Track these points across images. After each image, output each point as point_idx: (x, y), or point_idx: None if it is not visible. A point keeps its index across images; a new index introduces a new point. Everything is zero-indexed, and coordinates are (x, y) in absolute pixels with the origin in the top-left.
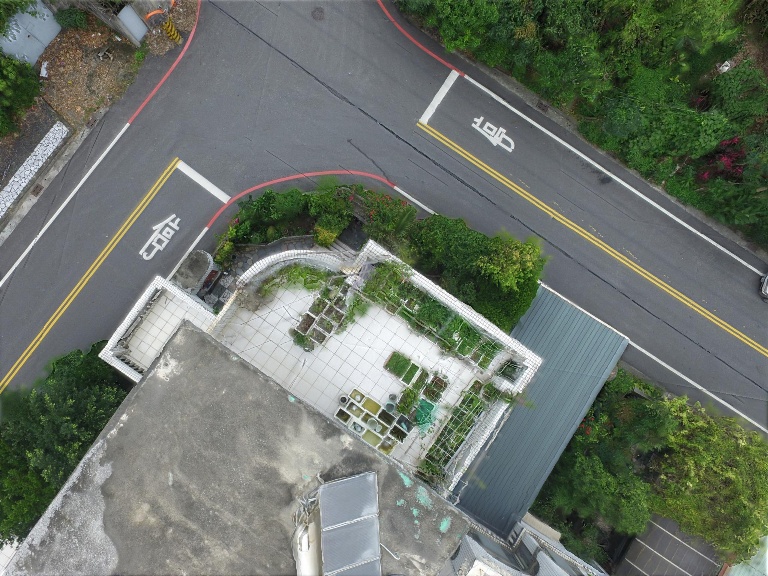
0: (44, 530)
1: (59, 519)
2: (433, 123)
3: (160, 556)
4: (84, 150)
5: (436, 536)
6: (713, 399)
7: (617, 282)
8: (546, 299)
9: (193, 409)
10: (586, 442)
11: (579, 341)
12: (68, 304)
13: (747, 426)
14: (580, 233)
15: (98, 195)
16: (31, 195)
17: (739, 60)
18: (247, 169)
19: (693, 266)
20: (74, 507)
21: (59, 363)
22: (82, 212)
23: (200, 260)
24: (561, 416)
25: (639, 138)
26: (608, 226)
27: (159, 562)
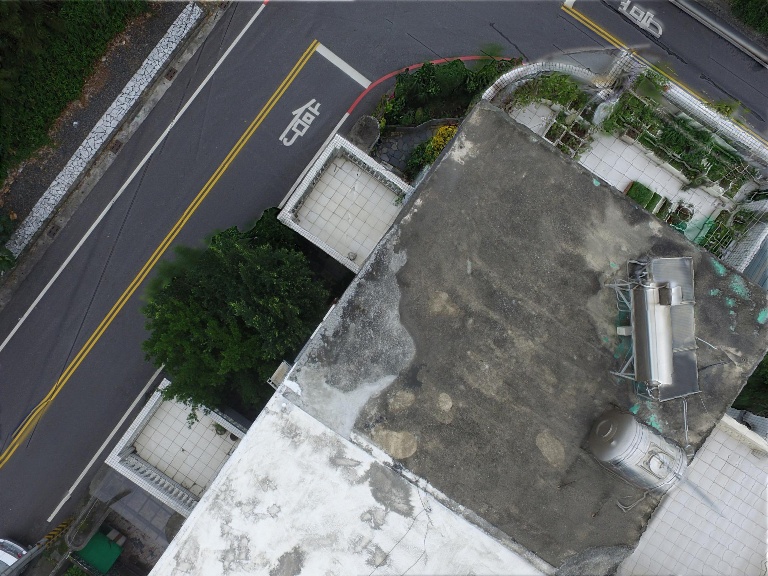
0: (337, 320)
1: (352, 308)
2: (578, 7)
3: (460, 347)
4: (218, 32)
5: (754, 327)
6: None
7: (767, 174)
8: None
9: (492, 194)
10: None
11: None
12: (208, 190)
13: None
14: None
15: (235, 78)
16: (165, 79)
17: None
18: (388, 52)
19: None
20: (368, 296)
21: (222, 235)
22: (219, 96)
23: (370, 126)
24: None
25: None
26: None
27: (459, 354)
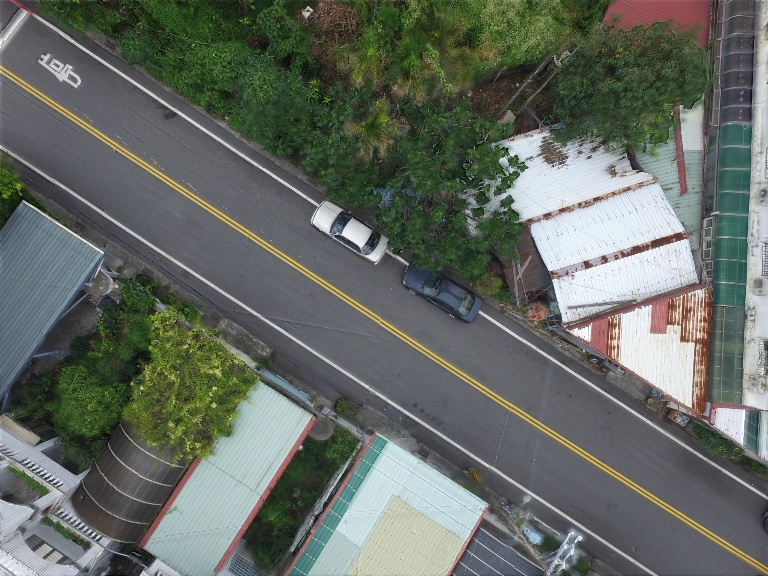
0: None
1: None
2: None
3: None
4: None
5: None
6: (267, 325)
7: (176, 213)
8: (26, 215)
9: None
10: (96, 357)
11: (55, 255)
12: None
13: (301, 351)
14: (141, 166)
15: None
16: None
17: (325, 6)
18: None
19: (252, 198)
20: None
21: None
22: None
23: None
24: (29, 324)
25: (182, 73)
26: (169, 159)
27: None
